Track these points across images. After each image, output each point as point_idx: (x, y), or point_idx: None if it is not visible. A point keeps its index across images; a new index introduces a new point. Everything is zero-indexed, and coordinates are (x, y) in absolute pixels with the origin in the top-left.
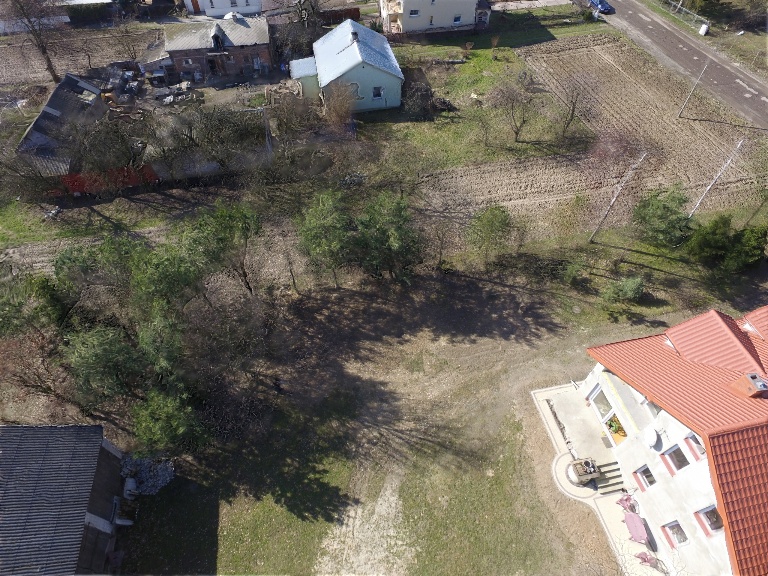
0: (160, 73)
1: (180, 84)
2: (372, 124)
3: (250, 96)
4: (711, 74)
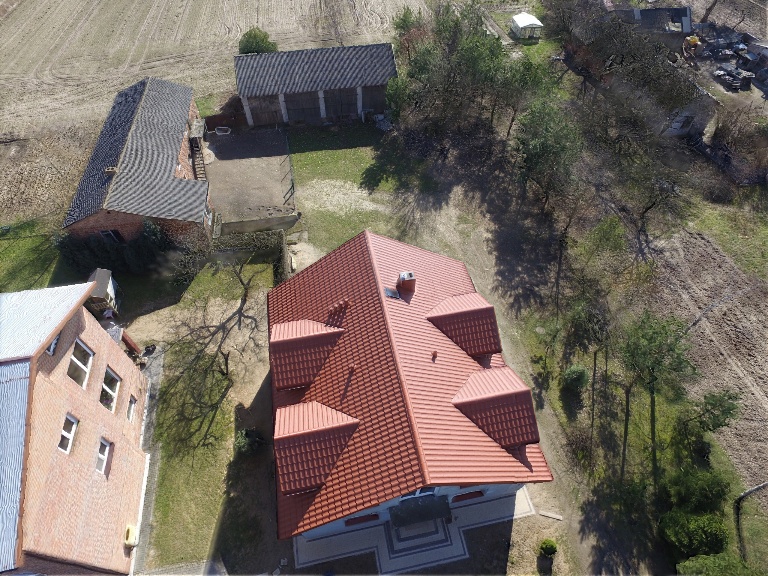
0: (751, 57)
1: (747, 72)
2: None
3: (766, 115)
4: None
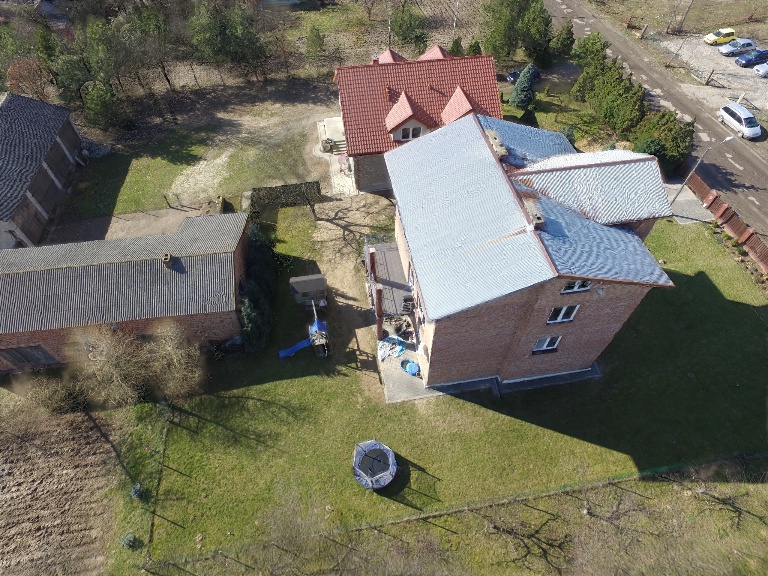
0: None
1: None
2: (277, 12)
3: None
4: None
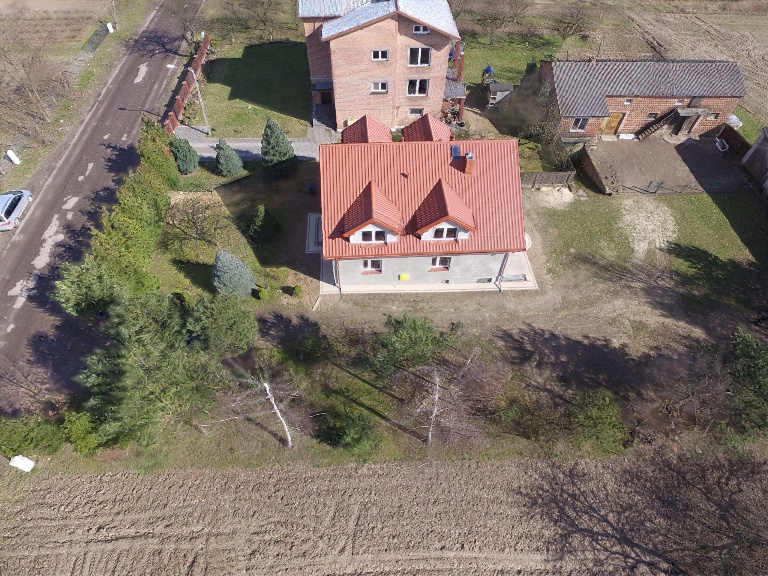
0: None
1: None
2: None
3: None
4: None
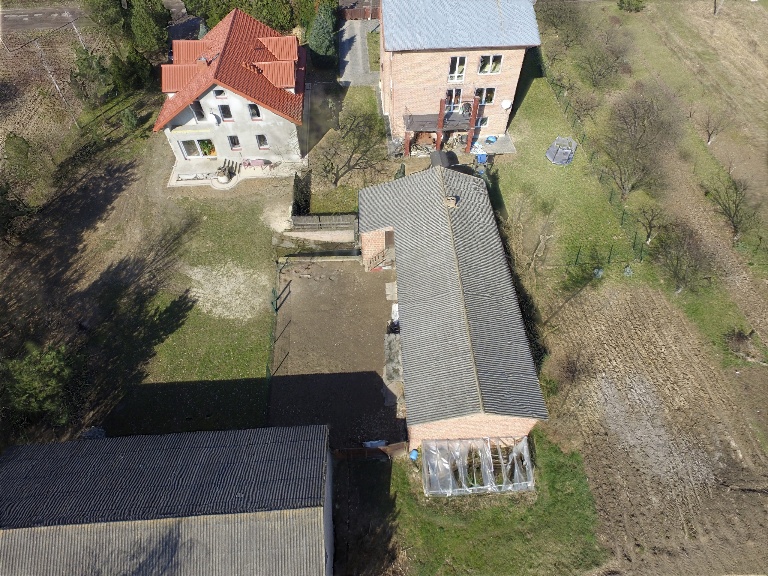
0: None
1: None
2: None
3: None
4: None
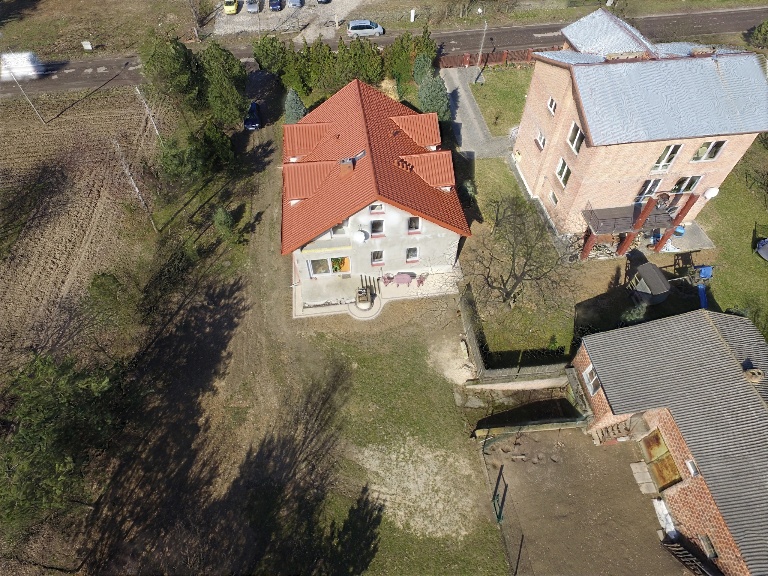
0: None
1: None
2: None
3: None
4: (6, 83)
